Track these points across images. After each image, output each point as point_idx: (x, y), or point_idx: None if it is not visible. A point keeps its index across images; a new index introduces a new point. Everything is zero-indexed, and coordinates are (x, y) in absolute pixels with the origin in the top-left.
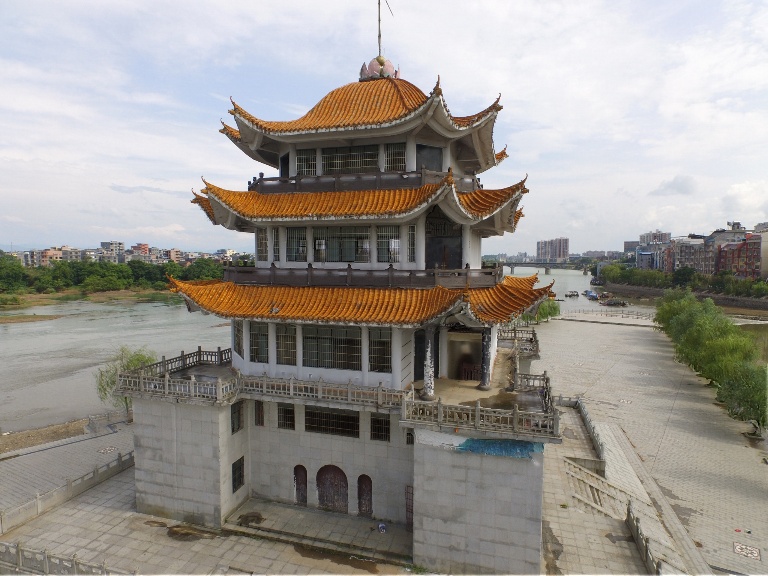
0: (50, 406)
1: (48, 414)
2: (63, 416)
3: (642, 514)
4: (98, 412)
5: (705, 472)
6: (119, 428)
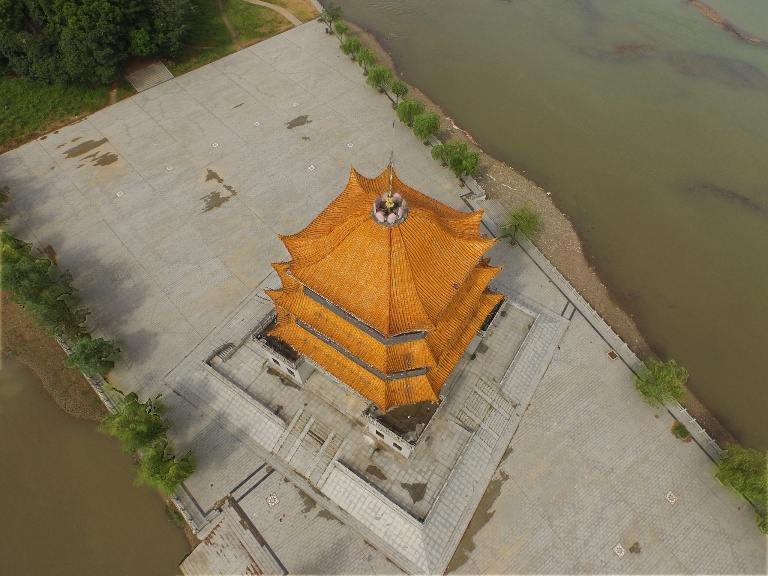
0: (598, 198)
1: (583, 201)
2: (580, 210)
3: (308, 465)
4: (585, 225)
5: (336, 575)
6: (503, 239)
